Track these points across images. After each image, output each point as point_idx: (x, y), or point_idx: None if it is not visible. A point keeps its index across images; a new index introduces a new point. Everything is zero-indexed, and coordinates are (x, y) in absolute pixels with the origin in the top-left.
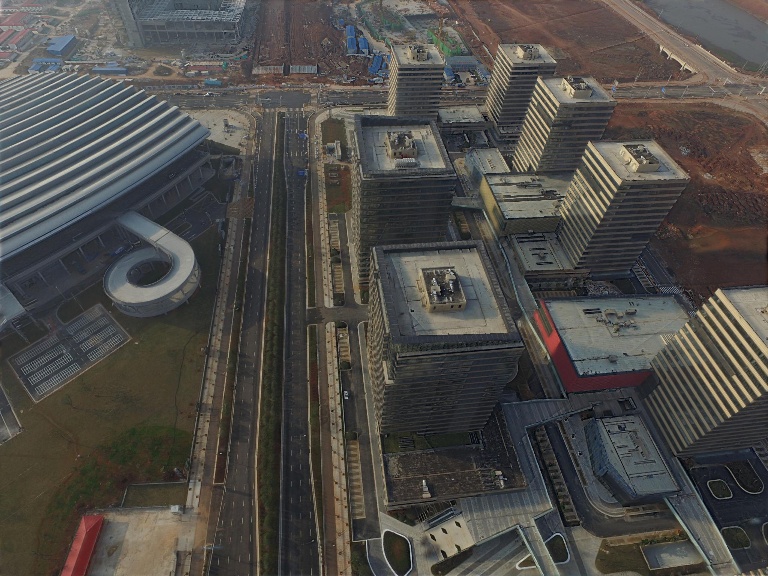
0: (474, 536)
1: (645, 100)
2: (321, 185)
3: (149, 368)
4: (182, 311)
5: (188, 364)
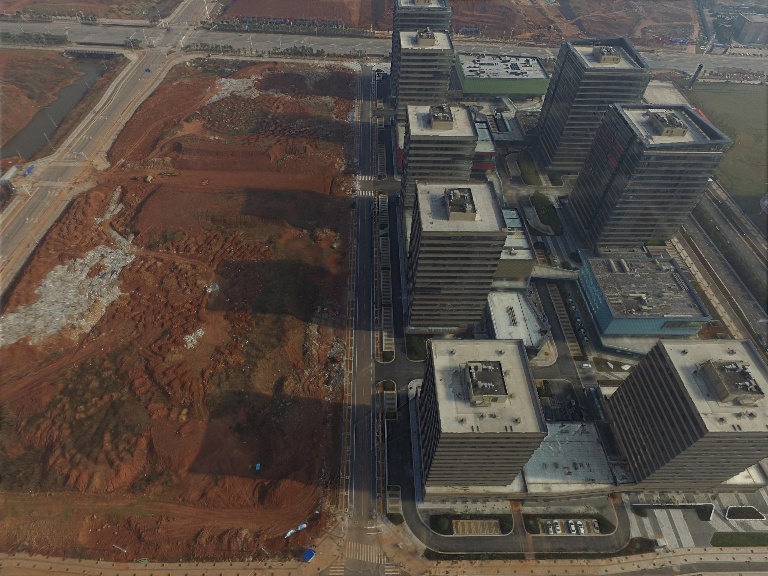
0: (538, 110)
1: (60, 575)
2: (730, 322)
3: (743, 172)
4: (757, 200)
5: (721, 173)
